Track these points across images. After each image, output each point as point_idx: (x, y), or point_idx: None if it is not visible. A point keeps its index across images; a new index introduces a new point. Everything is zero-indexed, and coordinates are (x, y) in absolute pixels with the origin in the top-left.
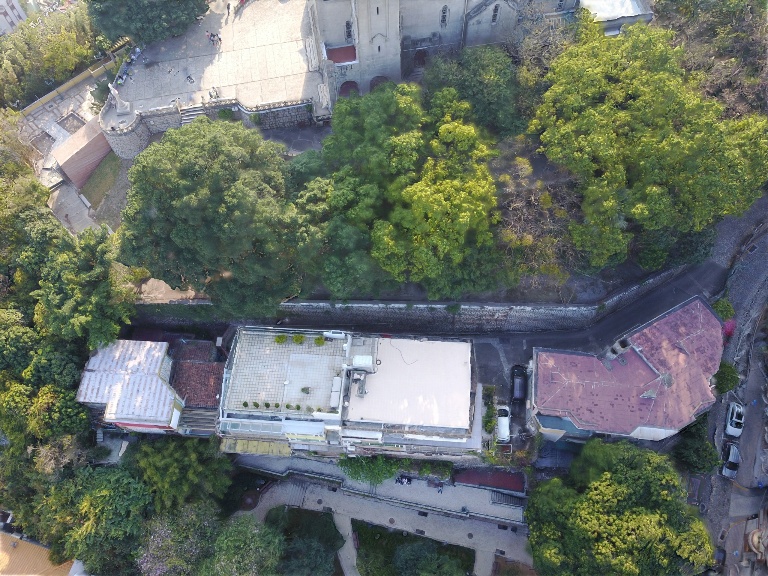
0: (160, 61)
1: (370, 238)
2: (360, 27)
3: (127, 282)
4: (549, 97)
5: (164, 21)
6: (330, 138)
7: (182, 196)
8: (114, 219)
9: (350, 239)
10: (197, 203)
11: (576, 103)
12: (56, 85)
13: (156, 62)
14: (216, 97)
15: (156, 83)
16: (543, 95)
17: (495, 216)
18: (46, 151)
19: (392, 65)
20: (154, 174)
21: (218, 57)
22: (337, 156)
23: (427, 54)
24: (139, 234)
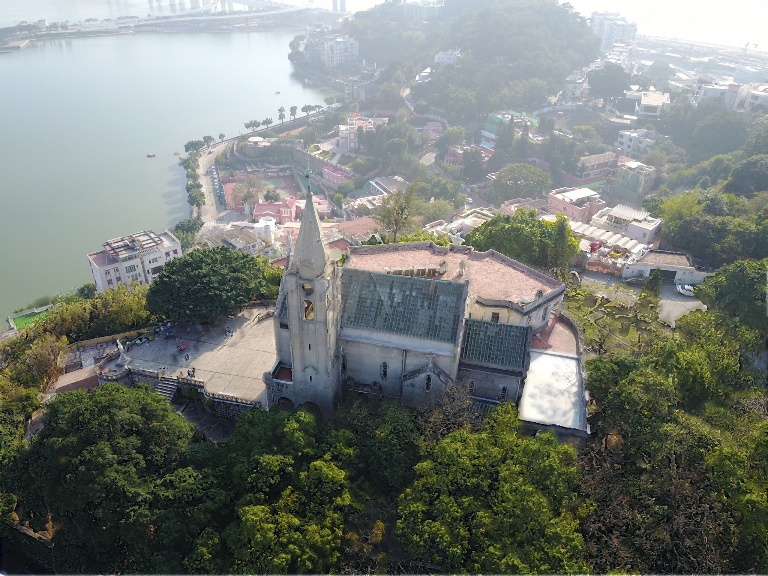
0: (179, 337)
1: (193, 543)
2: (294, 356)
3: (11, 502)
4: (417, 470)
5: (189, 310)
6: (231, 438)
7: (52, 436)
8: None
9: (169, 535)
10: (60, 447)
11: (437, 485)
12: (115, 332)
13: (175, 337)
14: (193, 376)
15: (162, 352)
16: (414, 466)
17: (329, 574)
18: None
19: (323, 396)
20: (52, 412)
21: (220, 348)
22: (223, 455)
23: (369, 399)
24: (19, 458)
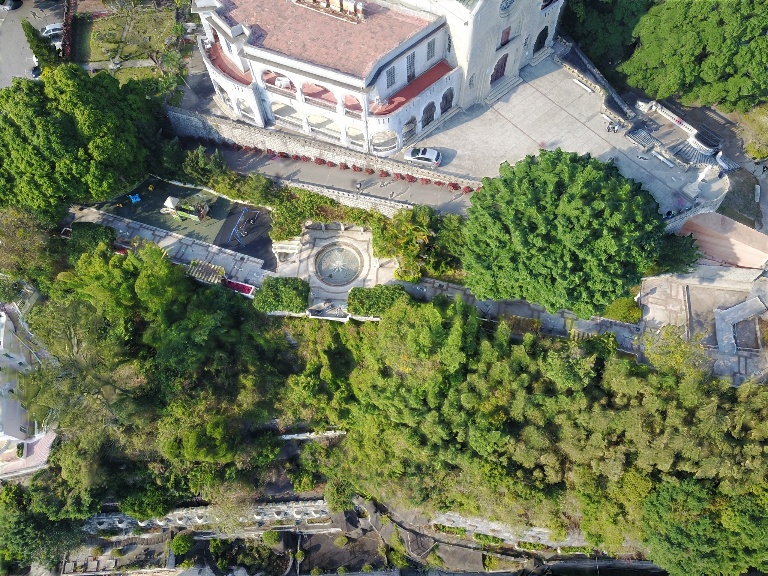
0: None
1: None
2: None
3: None
4: None
5: None
6: None
7: None
8: (747, 195)
9: None
10: None
11: None
12: None
13: None
14: None
15: None
16: None
17: None
18: (750, 327)
19: None
20: None
21: None
22: None
23: None
24: None
